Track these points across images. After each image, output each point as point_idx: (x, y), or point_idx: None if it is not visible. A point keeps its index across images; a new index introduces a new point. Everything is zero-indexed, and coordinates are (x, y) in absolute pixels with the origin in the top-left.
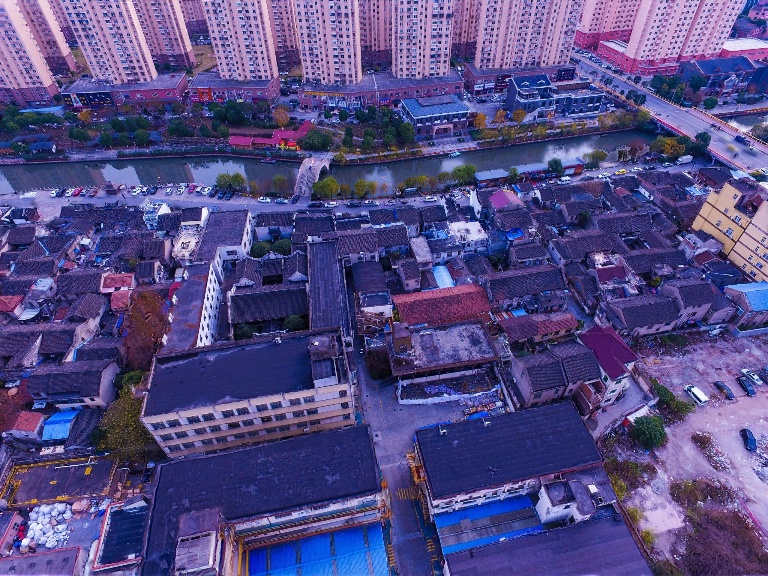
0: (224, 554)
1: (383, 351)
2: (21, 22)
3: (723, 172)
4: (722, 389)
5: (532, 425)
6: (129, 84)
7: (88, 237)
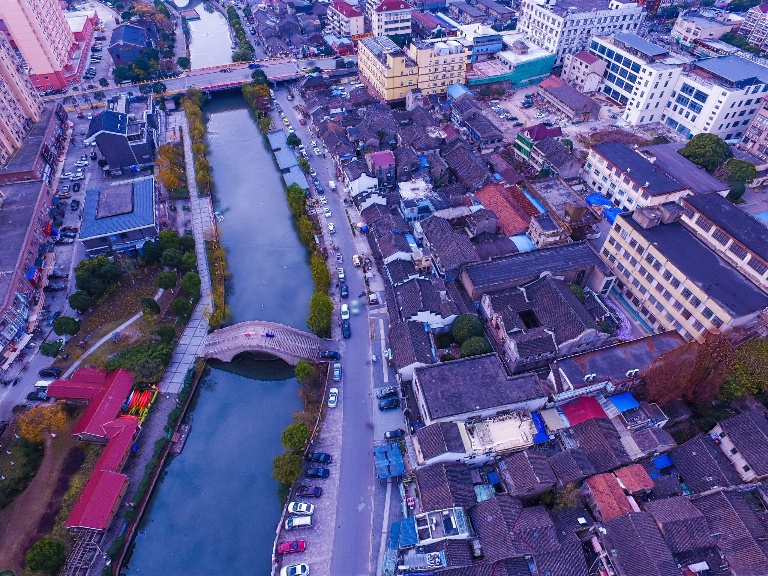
0: None
1: (579, 231)
2: None
3: (315, 77)
4: (519, 124)
5: (616, 158)
6: None
7: None
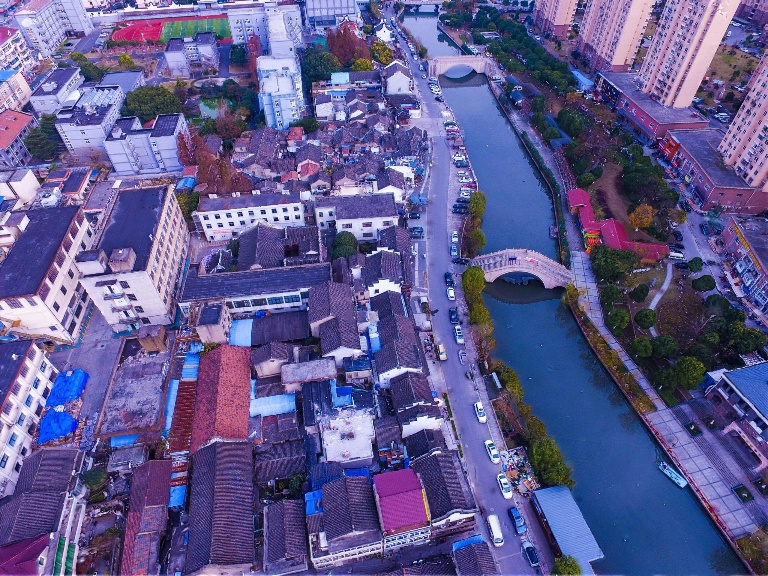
0: (1, 237)
1: None
2: (645, 1)
3: None
4: None
5: None
6: (649, 97)
7: (385, 150)
